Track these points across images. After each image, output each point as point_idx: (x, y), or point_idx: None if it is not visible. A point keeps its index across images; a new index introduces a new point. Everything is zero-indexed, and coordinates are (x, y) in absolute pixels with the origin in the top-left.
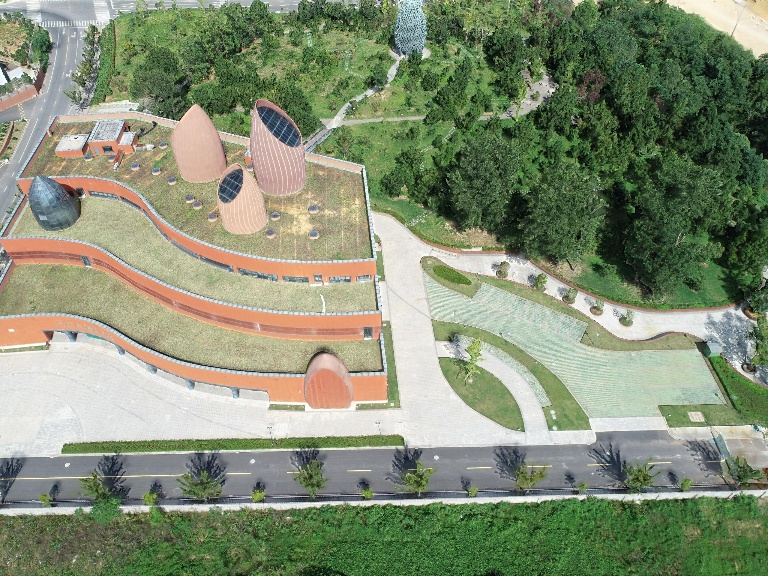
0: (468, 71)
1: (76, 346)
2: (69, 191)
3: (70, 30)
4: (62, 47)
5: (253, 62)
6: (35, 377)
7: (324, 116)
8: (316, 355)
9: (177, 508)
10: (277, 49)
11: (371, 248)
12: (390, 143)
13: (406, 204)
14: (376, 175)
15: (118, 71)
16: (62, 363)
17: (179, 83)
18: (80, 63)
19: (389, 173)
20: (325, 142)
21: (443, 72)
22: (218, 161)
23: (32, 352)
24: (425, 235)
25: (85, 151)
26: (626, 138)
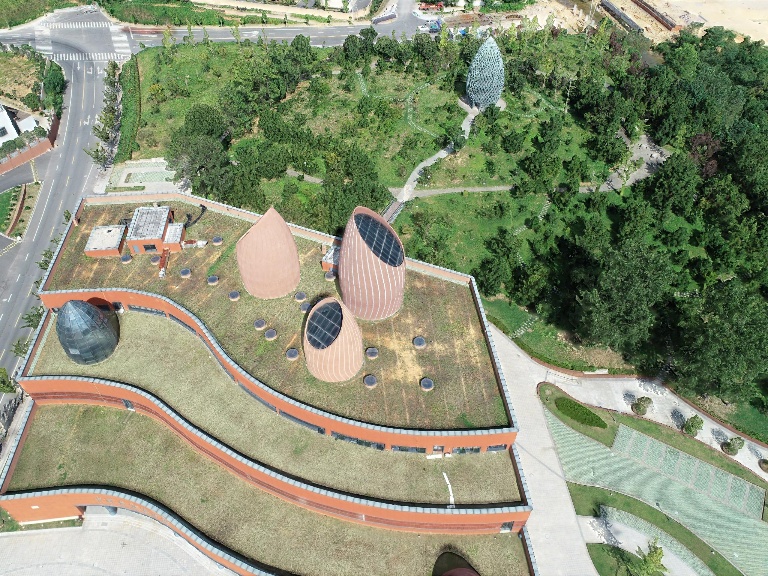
0: (557, 130)
1: (117, 521)
2: (104, 305)
3: (86, 65)
4: (77, 86)
5: (301, 111)
6: (66, 571)
7: (392, 184)
8: (441, 558)
9: None
10: (327, 95)
11: (504, 406)
12: (475, 222)
13: (506, 306)
14: (464, 265)
15: (145, 121)
16: (100, 548)
17: None
18: (102, 112)
19: (479, 263)
20: (397, 219)
21: (526, 130)
22: (293, 273)
23: (61, 529)
24: (536, 351)
25: (121, 248)
26: (763, 225)
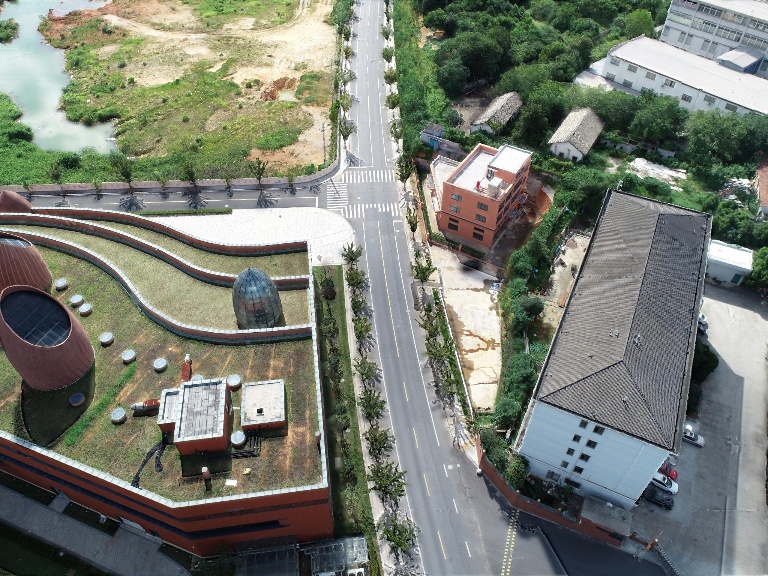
0: None
1: None
2: None
3: None
4: None
5: None
6: None
7: None
8: None
9: (148, 183)
10: None
11: None
12: None
13: None
14: None
15: None
16: None
17: None
18: None
19: None
20: None
21: None
22: None
23: None
24: None
25: None
26: None
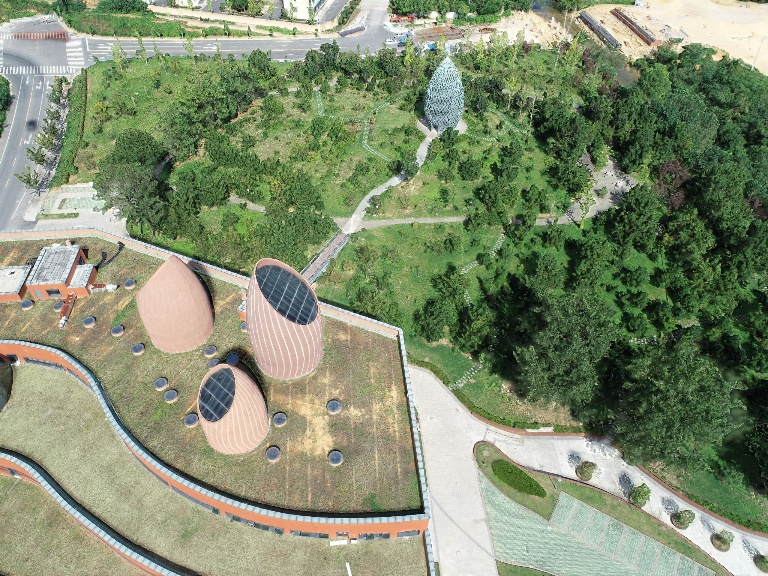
0: (517, 156)
1: None
2: None
3: (35, 79)
4: (23, 102)
5: (251, 132)
6: None
7: (339, 214)
8: None
9: None
10: (280, 115)
11: (419, 486)
12: (423, 257)
13: (448, 353)
14: (407, 305)
15: (86, 142)
16: None
17: (160, 160)
18: (39, 133)
19: (424, 303)
20: (341, 253)
21: (485, 155)
22: (201, 325)
23: None
24: (476, 405)
25: (24, 292)
26: (729, 265)
